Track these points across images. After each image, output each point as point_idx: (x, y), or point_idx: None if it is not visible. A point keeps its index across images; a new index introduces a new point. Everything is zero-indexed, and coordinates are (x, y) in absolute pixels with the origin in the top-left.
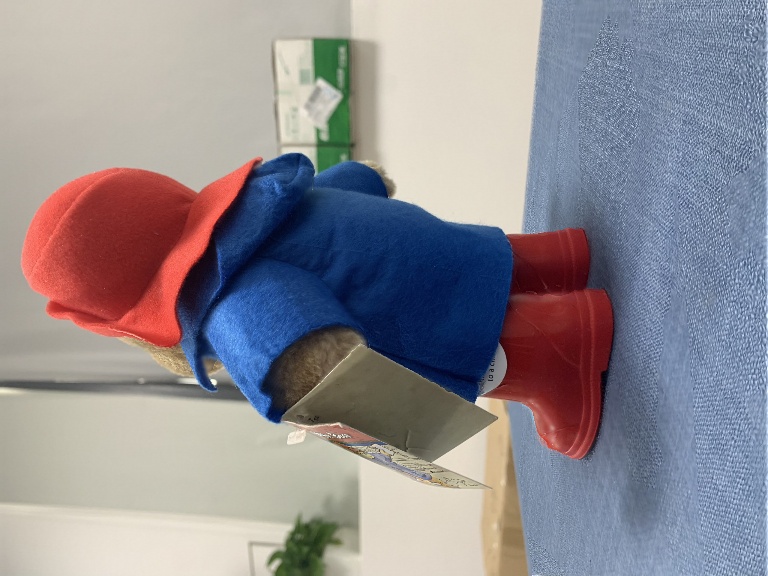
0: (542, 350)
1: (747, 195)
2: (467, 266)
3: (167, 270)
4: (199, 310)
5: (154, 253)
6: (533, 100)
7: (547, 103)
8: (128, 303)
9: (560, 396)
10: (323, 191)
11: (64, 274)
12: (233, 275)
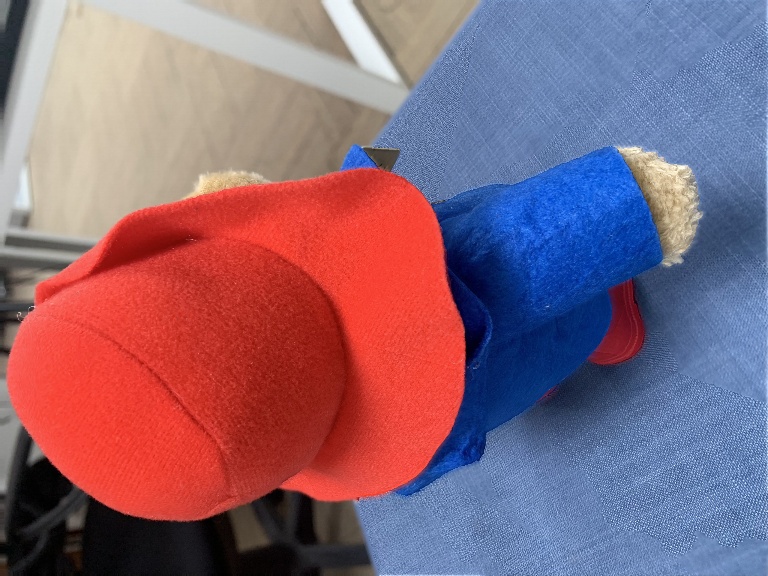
0: None
1: (489, 575)
2: None
3: None
4: None
5: None
6: None
7: None
8: None
9: None
10: None
11: None
12: None
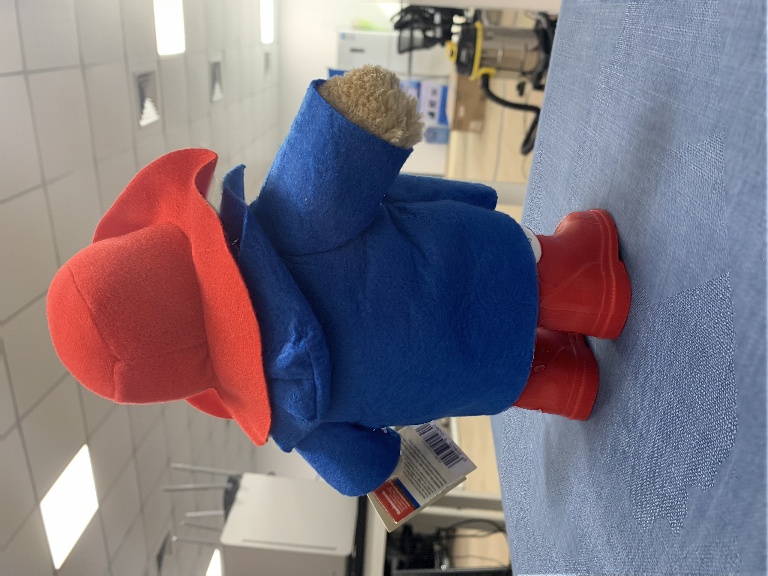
0: None
1: None
2: None
3: None
4: None
5: None
6: None
7: None
8: None
9: None
10: (339, 339)
11: None
12: None
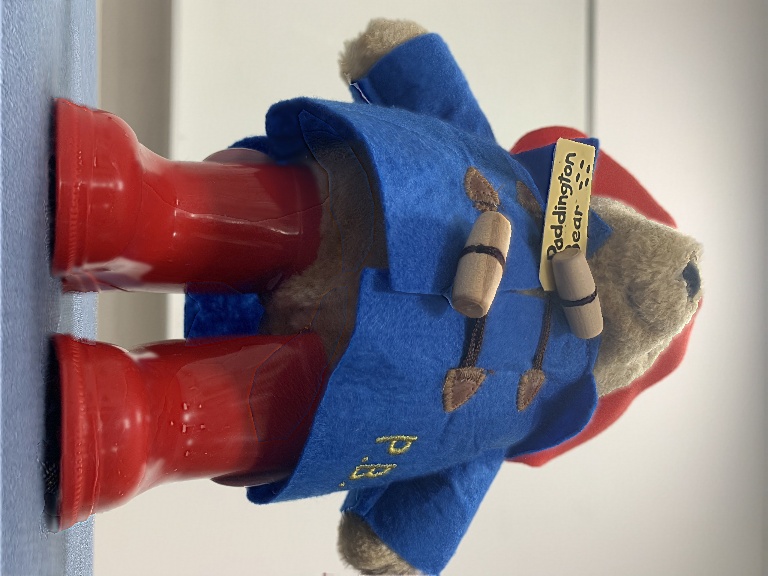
0: None
1: None
2: None
3: None
4: None
5: None
6: None
7: None
8: None
9: None
10: None
11: None
12: None
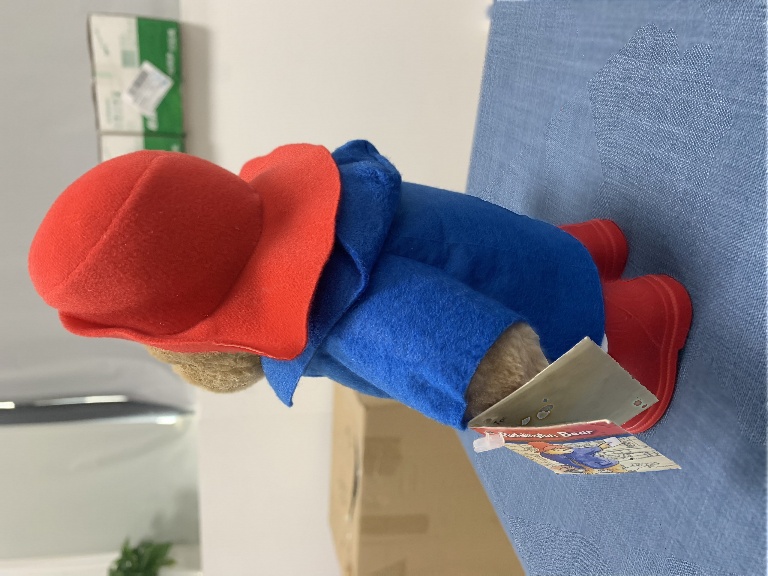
0: (633, 334)
1: None
2: (560, 256)
3: (274, 270)
4: (330, 314)
5: (237, 251)
6: (484, 98)
7: (516, 101)
8: (201, 312)
9: (642, 376)
10: None
11: (123, 280)
12: (371, 273)
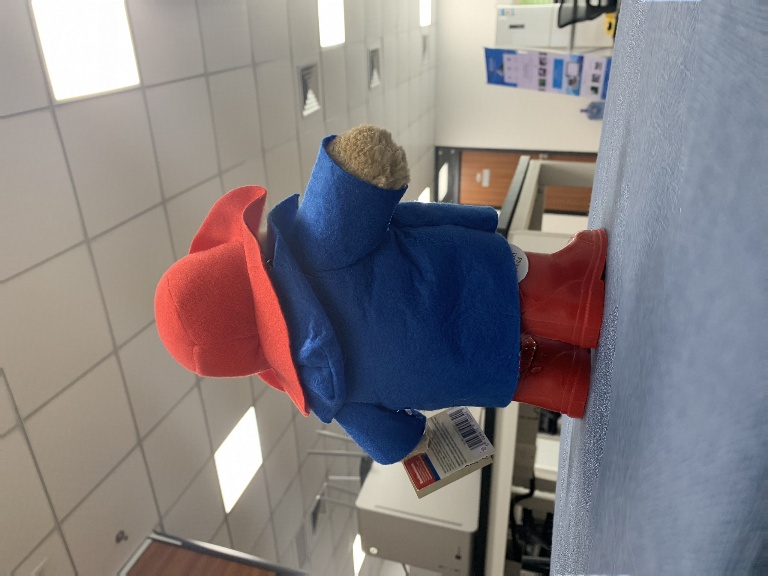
0: None
1: None
2: None
3: None
4: None
5: None
6: None
7: None
8: None
9: None
10: (351, 337)
11: None
12: None
